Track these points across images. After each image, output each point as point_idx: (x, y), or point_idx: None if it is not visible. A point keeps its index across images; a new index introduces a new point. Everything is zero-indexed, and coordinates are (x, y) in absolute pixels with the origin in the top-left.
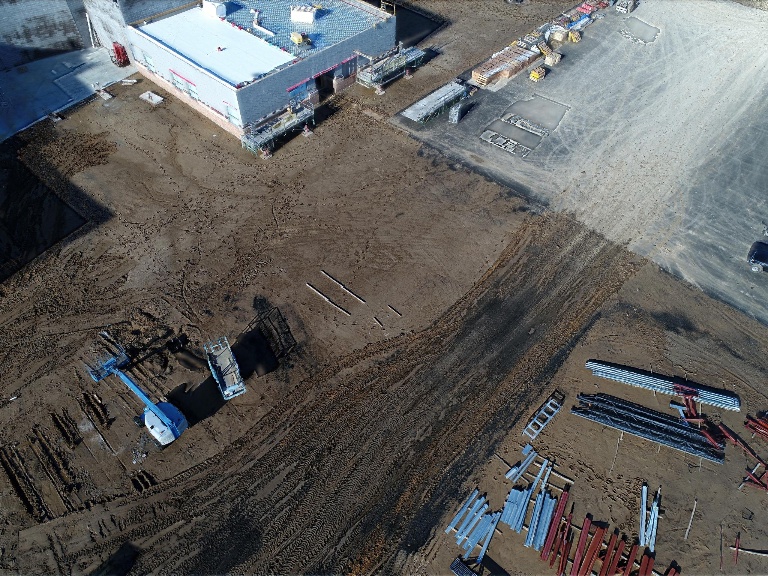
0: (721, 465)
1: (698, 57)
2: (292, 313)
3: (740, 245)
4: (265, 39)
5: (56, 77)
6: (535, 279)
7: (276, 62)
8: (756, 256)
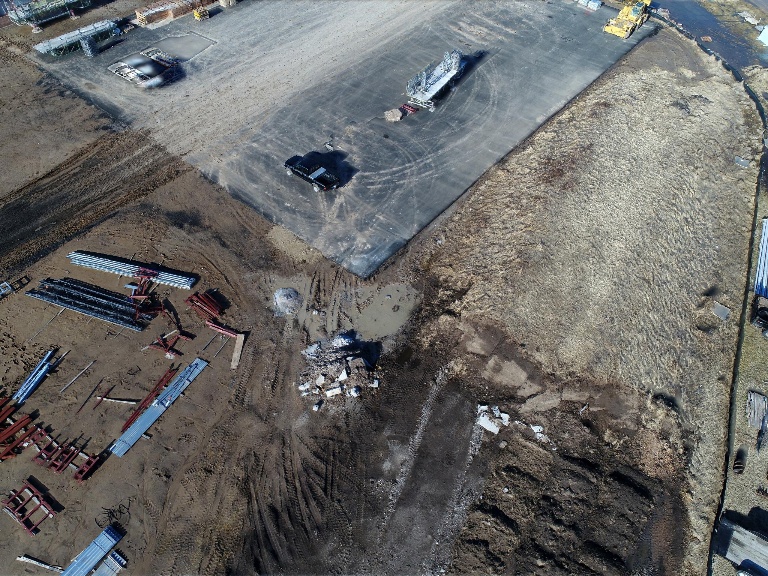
0: (139, 332)
1: None
2: None
3: (294, 154)
4: None
5: None
6: (75, 186)
7: None
8: (288, 160)
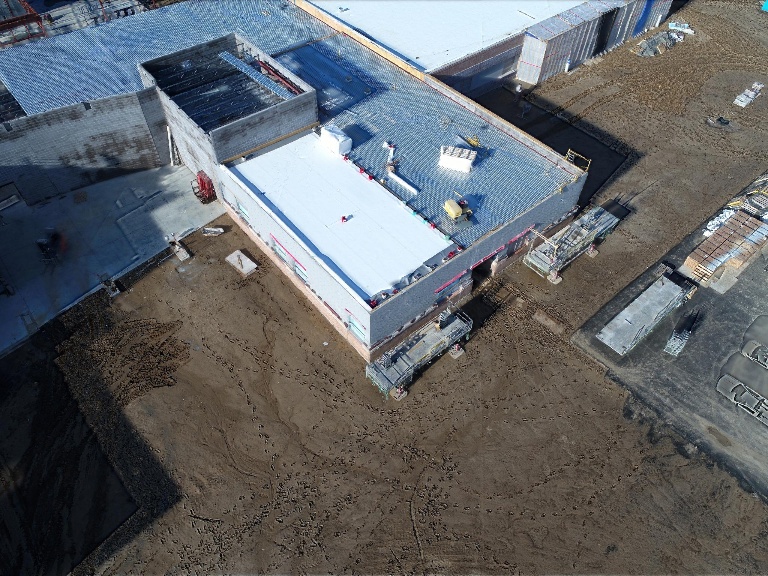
0: None
1: None
2: None
3: None
4: (406, 200)
5: (121, 214)
6: None
7: (424, 250)
8: None
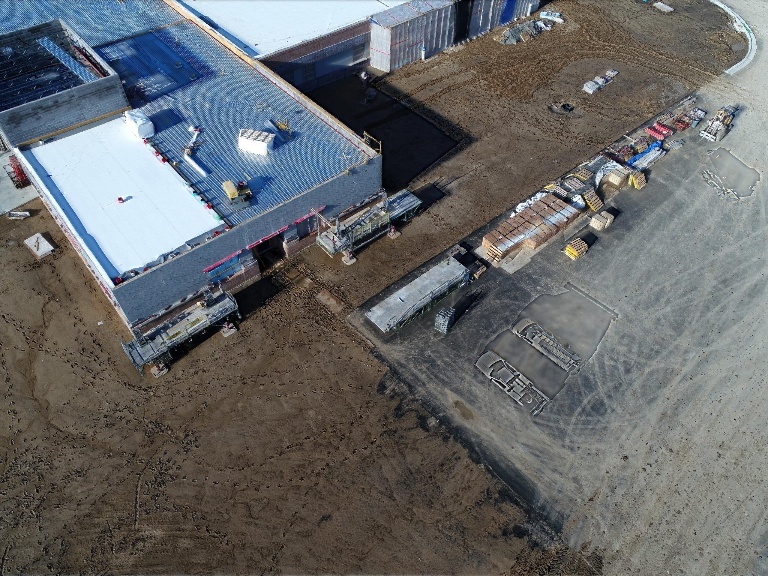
0: None
1: None
2: None
3: None
4: (192, 182)
5: None
6: None
7: (192, 230)
8: None
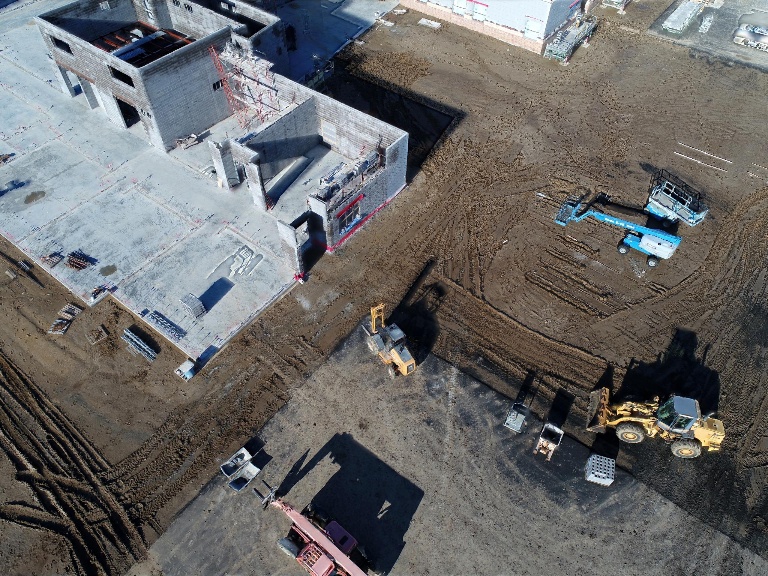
0: None
1: None
2: (679, 172)
3: None
4: None
5: (330, 10)
6: None
7: None
8: None
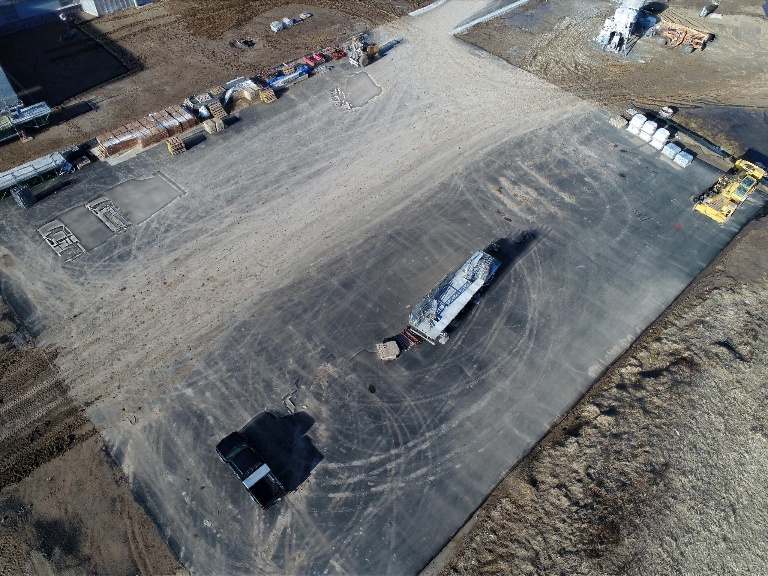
0: None
1: (398, 131)
2: None
3: (238, 416)
4: None
5: None
6: None
7: None
8: (221, 443)
